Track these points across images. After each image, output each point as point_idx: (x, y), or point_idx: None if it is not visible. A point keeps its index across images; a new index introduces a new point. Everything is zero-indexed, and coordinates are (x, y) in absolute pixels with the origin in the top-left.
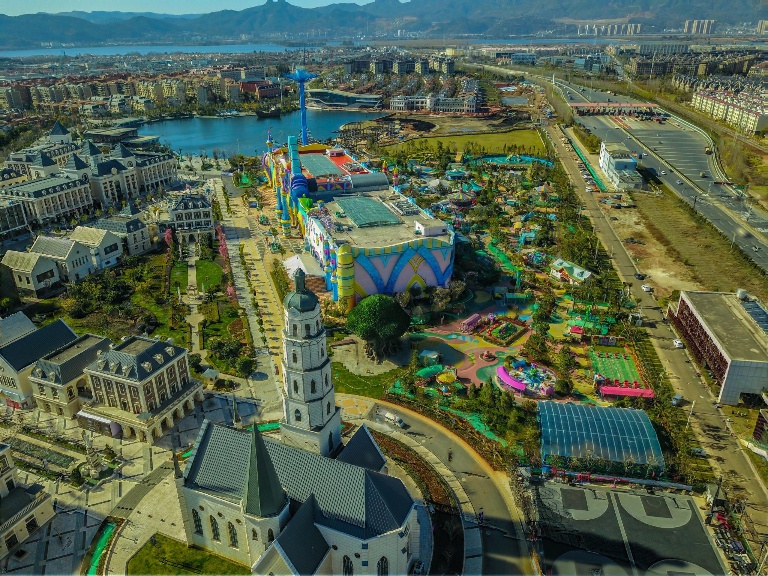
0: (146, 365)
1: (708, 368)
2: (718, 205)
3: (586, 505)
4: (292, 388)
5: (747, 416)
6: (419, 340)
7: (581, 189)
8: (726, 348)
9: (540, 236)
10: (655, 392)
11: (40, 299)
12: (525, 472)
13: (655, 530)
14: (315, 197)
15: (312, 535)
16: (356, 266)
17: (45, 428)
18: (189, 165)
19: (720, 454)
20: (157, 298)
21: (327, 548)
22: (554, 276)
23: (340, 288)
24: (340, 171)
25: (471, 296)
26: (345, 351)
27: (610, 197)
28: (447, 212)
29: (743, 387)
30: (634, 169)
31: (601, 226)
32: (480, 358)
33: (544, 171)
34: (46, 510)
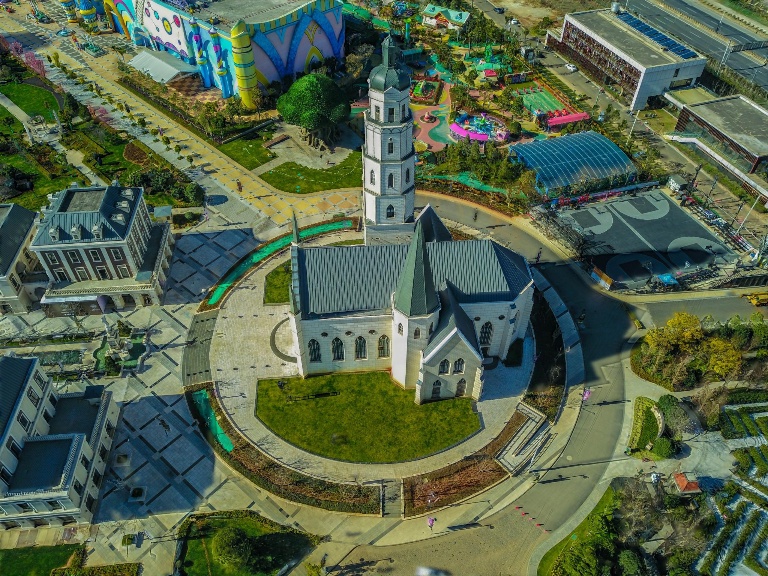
0: (119, 218)
1: (607, 83)
2: None
3: (597, 221)
4: (386, 183)
5: (657, 116)
6: (351, 118)
7: None
8: (636, 59)
9: None
10: None
11: None
12: (542, 209)
13: (654, 222)
14: None
15: (462, 315)
16: (253, 48)
17: (1, 334)
18: None
19: None
20: None
21: (471, 322)
22: (428, 24)
23: (242, 79)
24: None
25: None
26: (286, 149)
27: None
28: None
29: (651, 91)
30: None
31: None
32: (422, 122)
33: None
34: (113, 408)
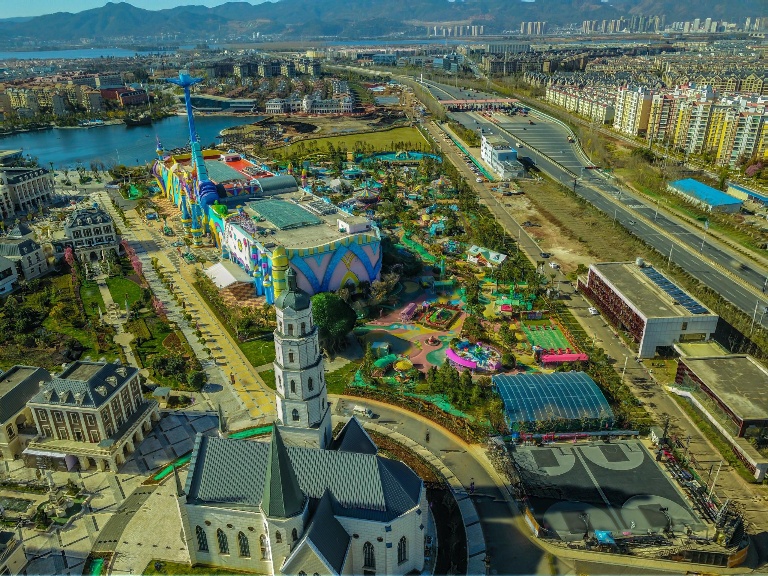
0: (101, 389)
1: (623, 329)
2: (592, 187)
3: (556, 462)
4: (289, 388)
5: (664, 366)
6: (364, 334)
7: (472, 180)
8: (640, 309)
9: (449, 226)
10: (587, 355)
11: None
12: (498, 441)
13: (619, 473)
14: (225, 203)
15: (334, 527)
16: None
17: None
18: (65, 179)
19: (652, 401)
20: (74, 321)
21: (348, 538)
22: (471, 262)
23: (277, 291)
24: (243, 176)
25: (401, 287)
26: None
27: (500, 186)
28: (355, 210)
29: (658, 341)
30: (515, 159)
31: (499, 213)
32: (426, 344)
33: (434, 165)
34: (18, 558)
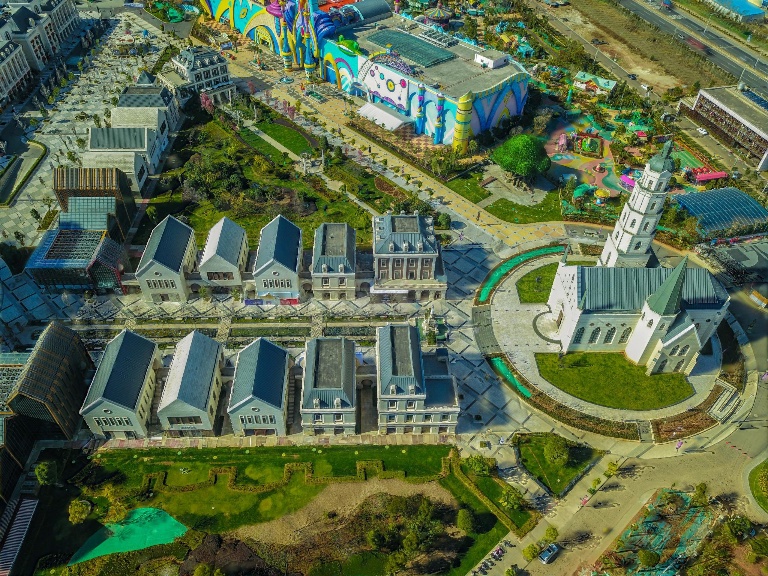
0: (433, 238)
1: (734, 147)
2: None
3: (746, 257)
4: (643, 228)
5: None
6: None
7: None
8: (765, 132)
9: (537, 48)
10: None
11: (146, 199)
12: (706, 246)
13: None
14: (336, 35)
15: None
16: None
17: (343, 312)
18: None
19: None
20: (277, 173)
21: None
22: (578, 87)
23: (461, 132)
24: None
25: None
26: (497, 188)
27: None
28: None
29: None
30: None
31: (563, 29)
32: (595, 171)
33: None
34: None
